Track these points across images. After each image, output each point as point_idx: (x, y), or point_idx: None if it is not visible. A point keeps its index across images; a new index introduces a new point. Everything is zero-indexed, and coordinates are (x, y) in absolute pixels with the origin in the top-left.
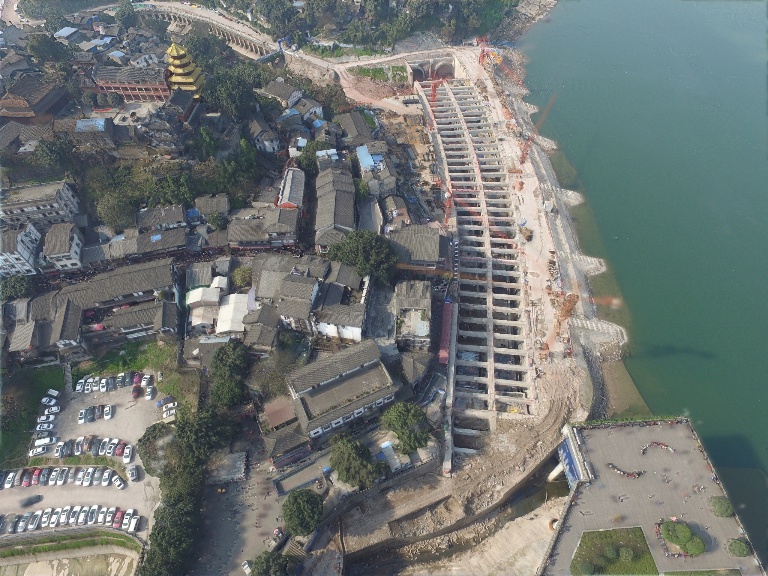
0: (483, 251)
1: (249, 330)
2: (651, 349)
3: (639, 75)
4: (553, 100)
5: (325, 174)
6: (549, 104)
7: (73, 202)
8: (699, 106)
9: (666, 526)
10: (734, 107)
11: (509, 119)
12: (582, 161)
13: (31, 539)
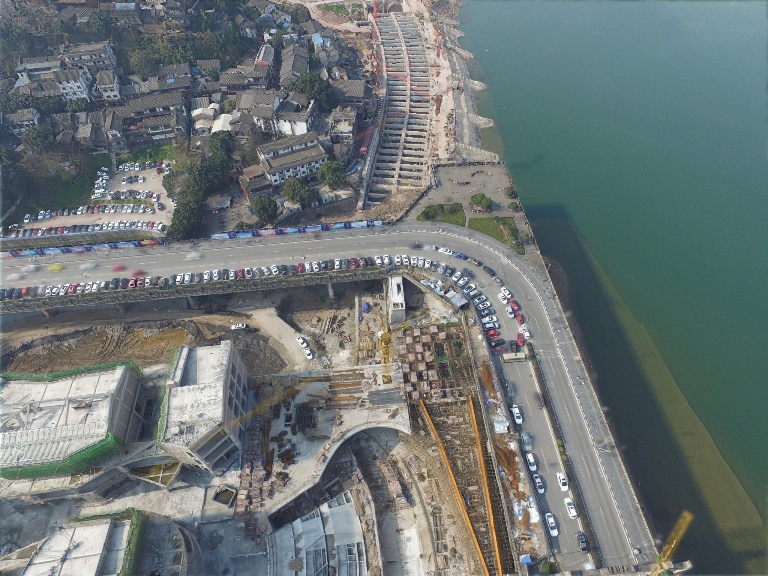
0: (404, 110)
1: (233, 127)
2: (514, 165)
3: (549, 12)
4: (478, 29)
5: (288, 47)
6: (474, 31)
7: (113, 57)
8: (590, 32)
9: (473, 196)
10: (616, 32)
11: (437, 36)
12: (491, 65)
13: (96, 238)
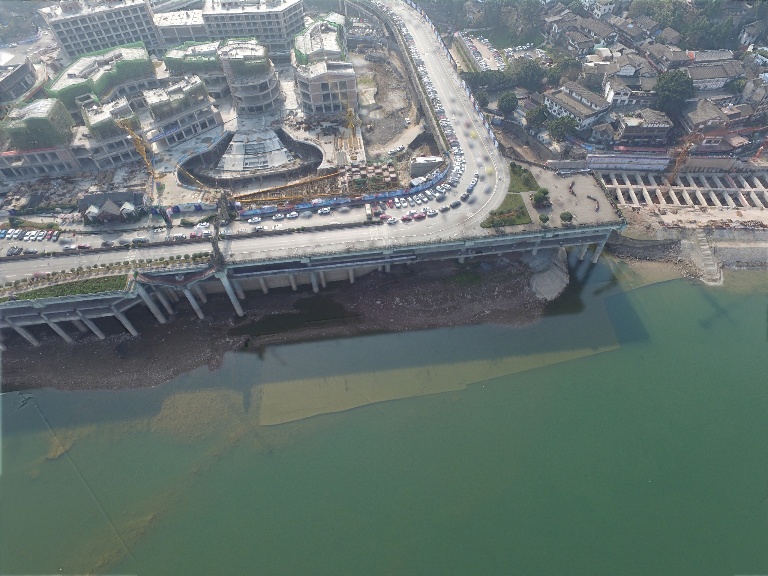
0: None
1: None
2: (709, 300)
3: None
4: None
5: None
6: None
7: None
8: None
9: None
10: None
11: None
12: None
13: (474, 64)
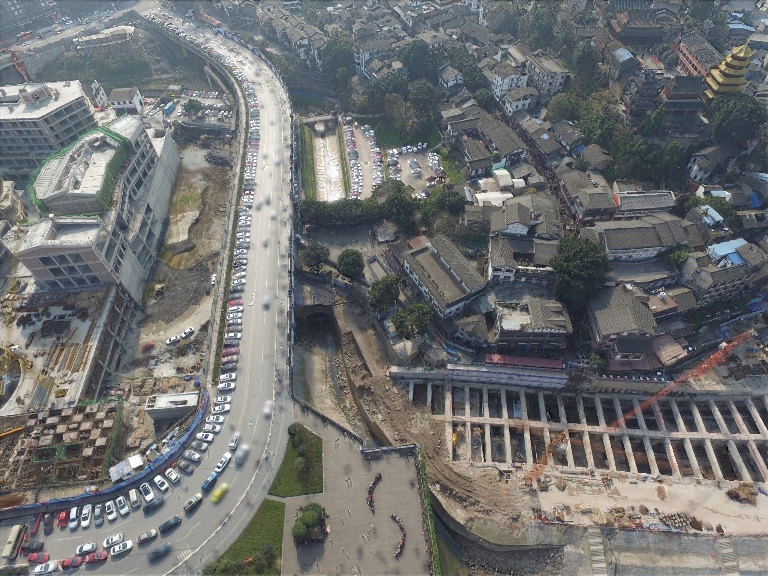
0: (680, 430)
1: None
2: None
3: None
4: None
5: (675, 216)
6: None
7: (556, 86)
8: None
9: (318, 506)
10: None
11: None
12: None
13: None
